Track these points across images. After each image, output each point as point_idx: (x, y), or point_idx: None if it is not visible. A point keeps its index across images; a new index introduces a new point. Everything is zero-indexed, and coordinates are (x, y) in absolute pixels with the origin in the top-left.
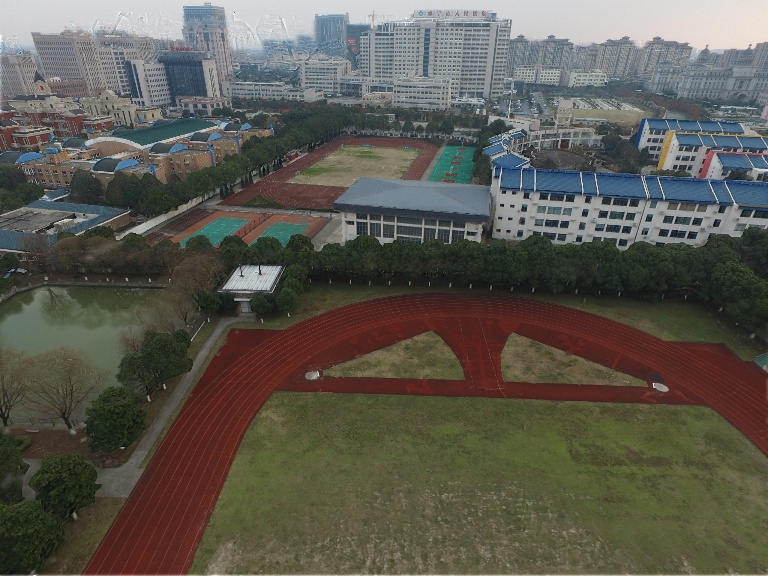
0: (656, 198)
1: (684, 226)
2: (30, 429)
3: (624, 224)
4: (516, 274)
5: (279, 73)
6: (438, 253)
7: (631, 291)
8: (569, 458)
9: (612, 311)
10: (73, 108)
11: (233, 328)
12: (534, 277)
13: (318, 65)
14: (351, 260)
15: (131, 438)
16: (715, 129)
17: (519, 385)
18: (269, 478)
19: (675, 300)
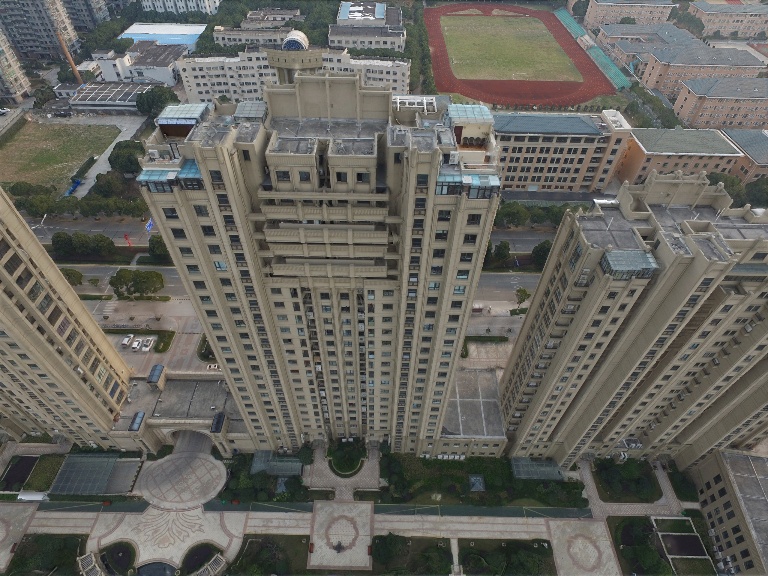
0: None
1: None
2: None
3: None
4: None
5: None
6: None
7: (530, 1)
8: (504, 21)
9: None
10: None
11: None
12: None
13: None
14: None
15: None
16: None
17: None
18: None
19: (543, 4)
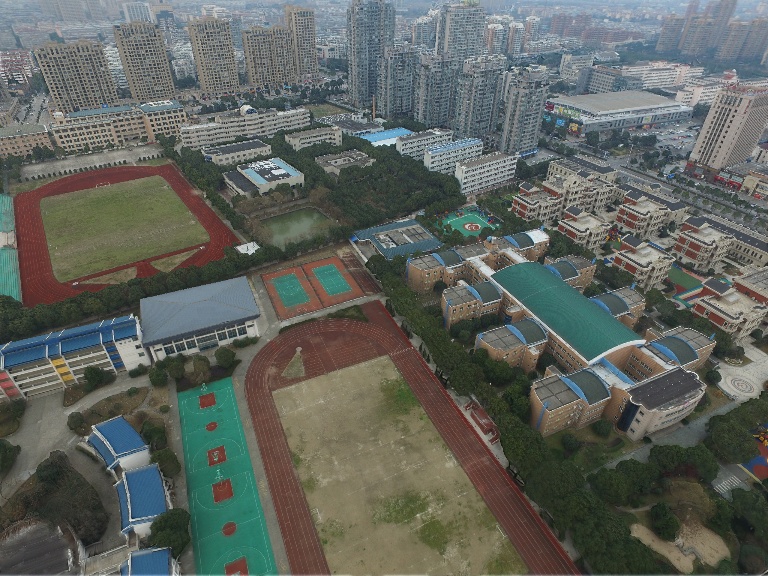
0: None
1: None
2: None
3: None
4: None
5: None
6: (167, 273)
7: None
8: None
9: None
10: (763, 292)
11: None
12: None
13: None
14: None
15: None
16: None
17: None
18: None
19: None
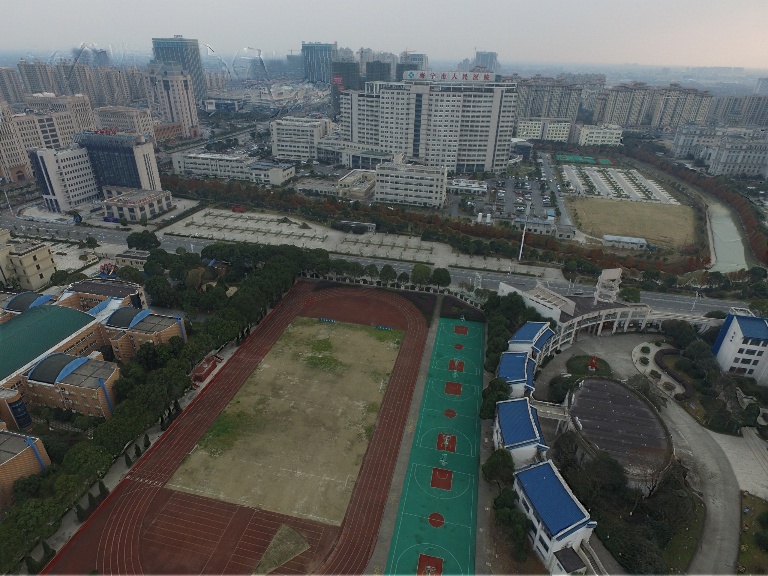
0: None
1: None
2: None
3: None
4: None
5: (256, 115)
6: None
7: None
8: None
9: None
10: None
11: None
12: None
13: (292, 126)
14: None
15: None
16: None
17: None
18: None
19: None
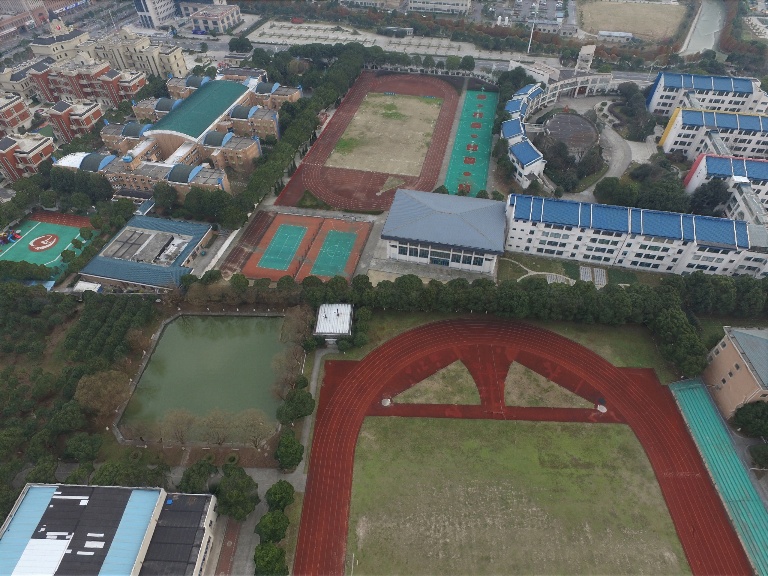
0: (636, 233)
1: (655, 252)
2: (233, 448)
3: (609, 248)
4: (519, 314)
5: None
6: (464, 297)
7: None
8: (538, 464)
9: (585, 337)
10: (104, 65)
11: (326, 360)
12: (532, 314)
13: None
14: (402, 302)
15: (299, 461)
16: (726, 88)
17: (514, 409)
18: (375, 479)
19: (632, 324)
